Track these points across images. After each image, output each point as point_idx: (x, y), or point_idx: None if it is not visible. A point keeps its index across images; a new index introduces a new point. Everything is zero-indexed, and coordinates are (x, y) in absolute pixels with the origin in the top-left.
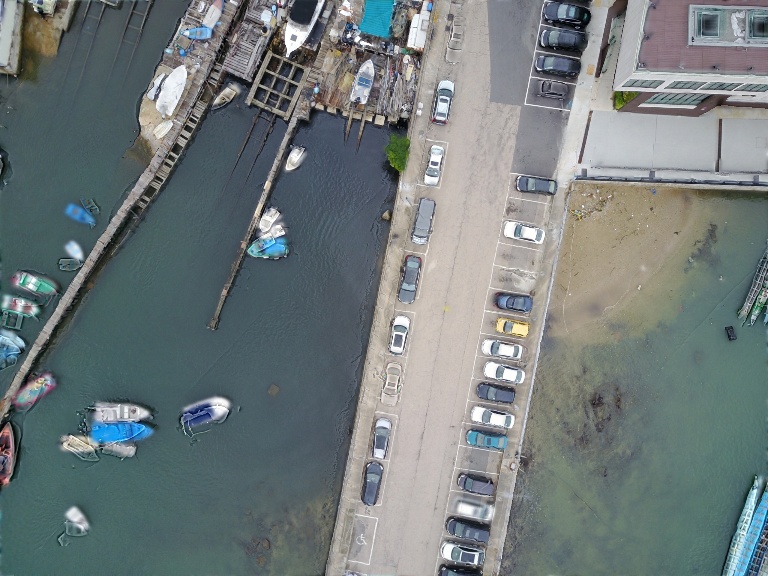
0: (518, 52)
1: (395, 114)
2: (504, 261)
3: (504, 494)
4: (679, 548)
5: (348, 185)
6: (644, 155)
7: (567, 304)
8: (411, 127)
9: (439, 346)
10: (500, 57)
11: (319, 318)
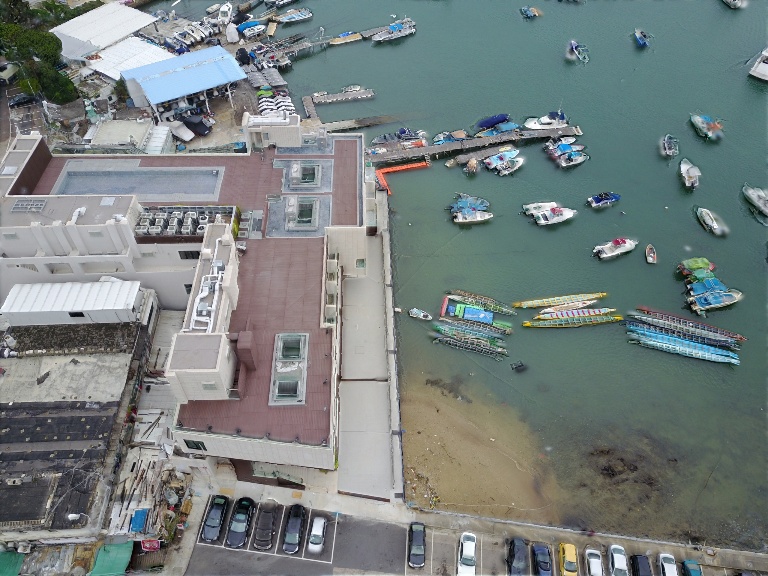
0: (276, 574)
1: None
2: None
3: (743, 561)
4: (712, 395)
5: None
6: (377, 441)
7: (523, 507)
8: None
9: None
10: None
11: None
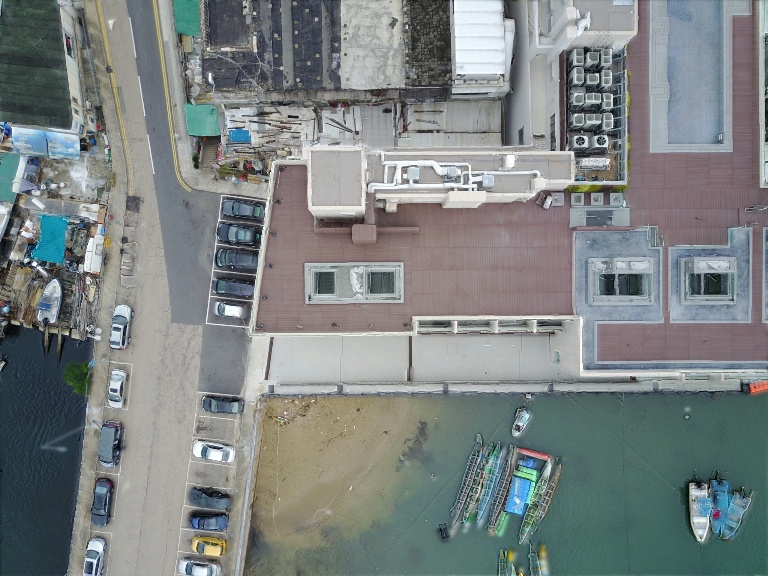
0: (195, 272)
1: (82, 334)
2: (197, 479)
3: None
4: None
5: (59, 392)
6: (331, 368)
7: (277, 509)
8: (93, 351)
9: (137, 566)
10: (177, 278)
11: (32, 530)
